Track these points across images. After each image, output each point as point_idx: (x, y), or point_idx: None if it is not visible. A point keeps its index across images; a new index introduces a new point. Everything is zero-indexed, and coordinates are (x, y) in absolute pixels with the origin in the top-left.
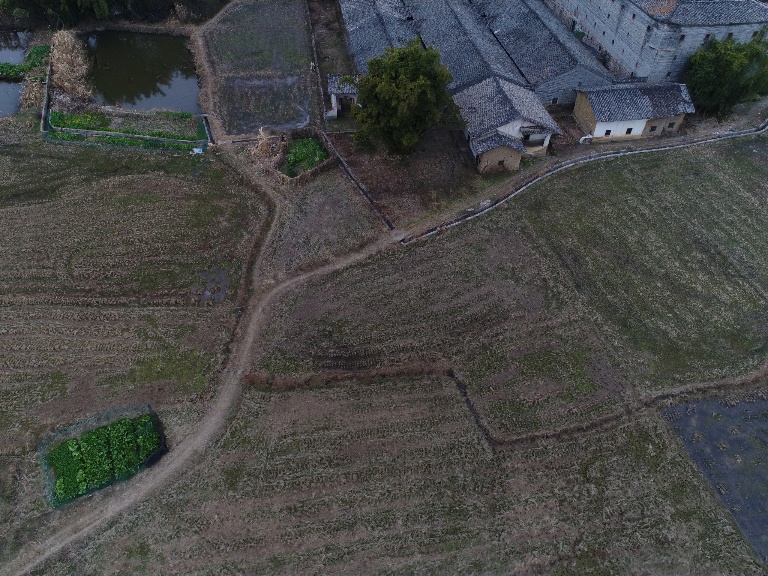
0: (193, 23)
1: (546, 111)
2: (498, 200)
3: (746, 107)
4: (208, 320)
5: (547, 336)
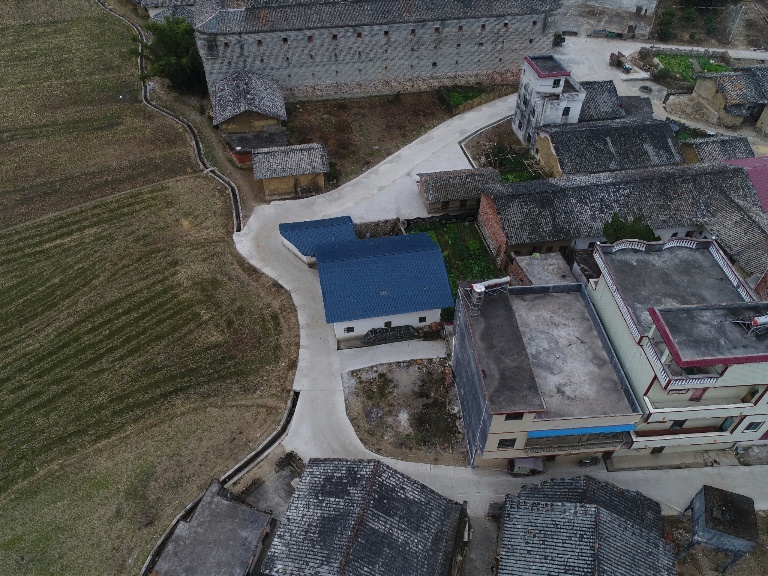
0: None
1: (173, 4)
2: None
3: (189, 104)
4: None
5: (1, 16)
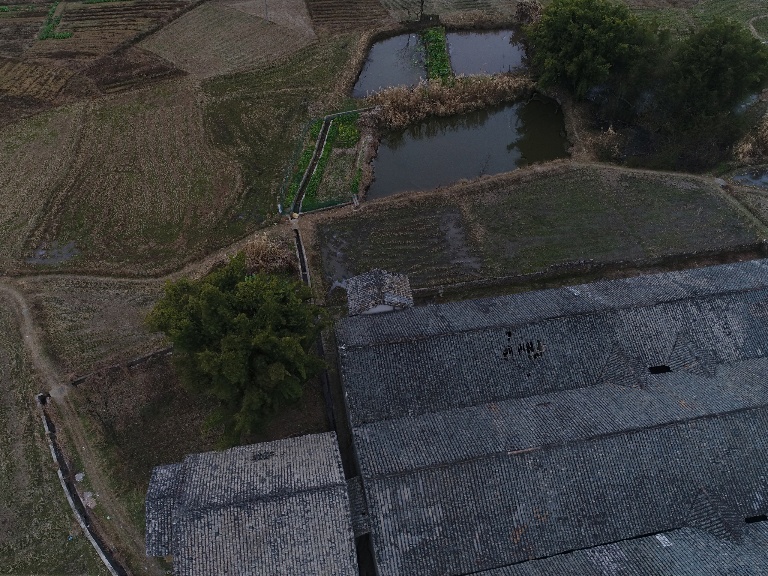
0: (603, 156)
1: None
2: (92, 520)
3: None
4: (1, 256)
5: None
